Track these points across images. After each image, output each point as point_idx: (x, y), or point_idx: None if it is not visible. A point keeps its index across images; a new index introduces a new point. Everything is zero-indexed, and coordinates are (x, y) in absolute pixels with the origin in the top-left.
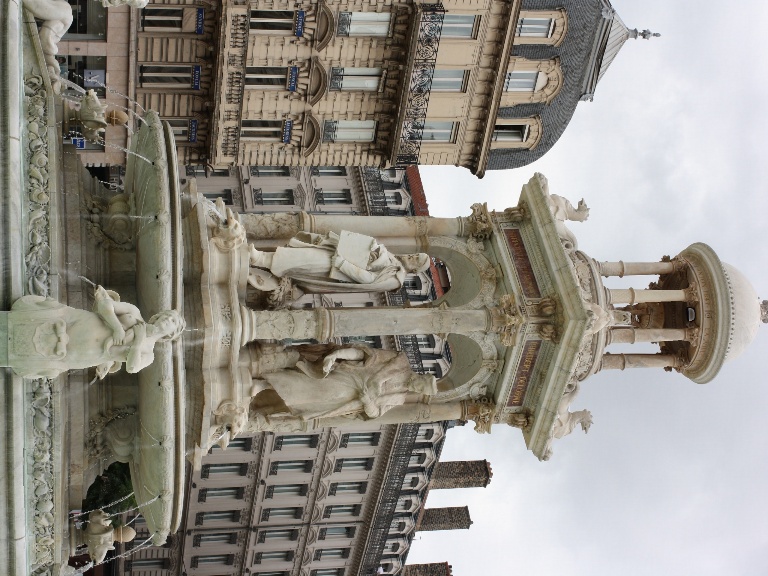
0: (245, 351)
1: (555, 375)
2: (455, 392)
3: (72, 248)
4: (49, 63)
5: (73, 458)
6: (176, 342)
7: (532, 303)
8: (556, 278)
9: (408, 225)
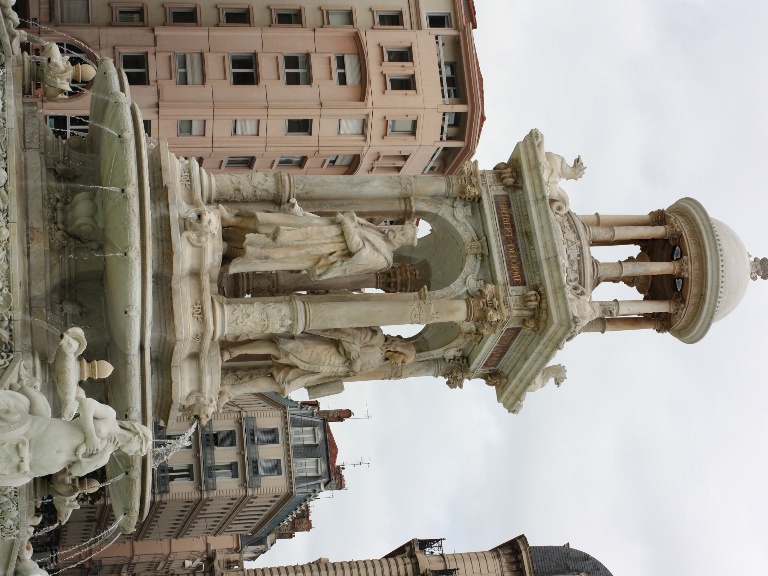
0: None
1: (535, 213)
2: (452, 291)
3: None
4: None
5: (31, 218)
6: None
7: None
8: None
9: None
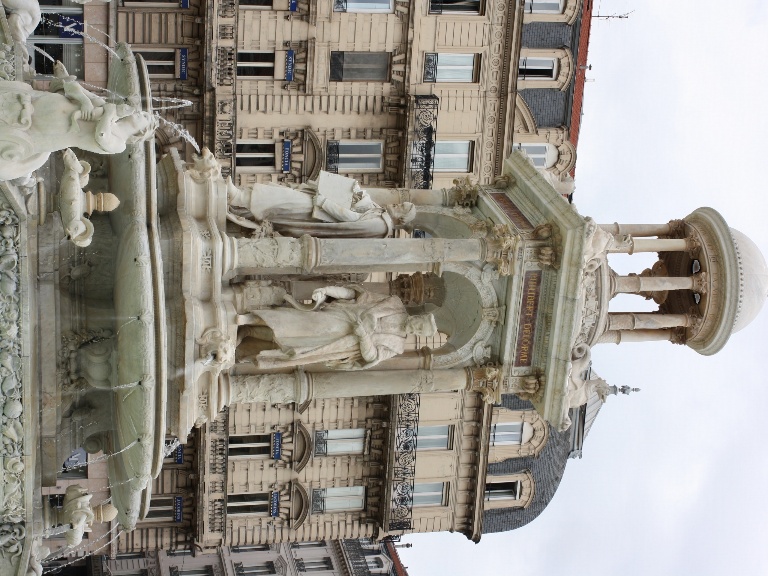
0: (228, 288)
1: (561, 309)
2: (457, 356)
3: None
4: None
5: (44, 383)
6: (152, 234)
7: (526, 232)
8: (548, 207)
9: (390, 193)
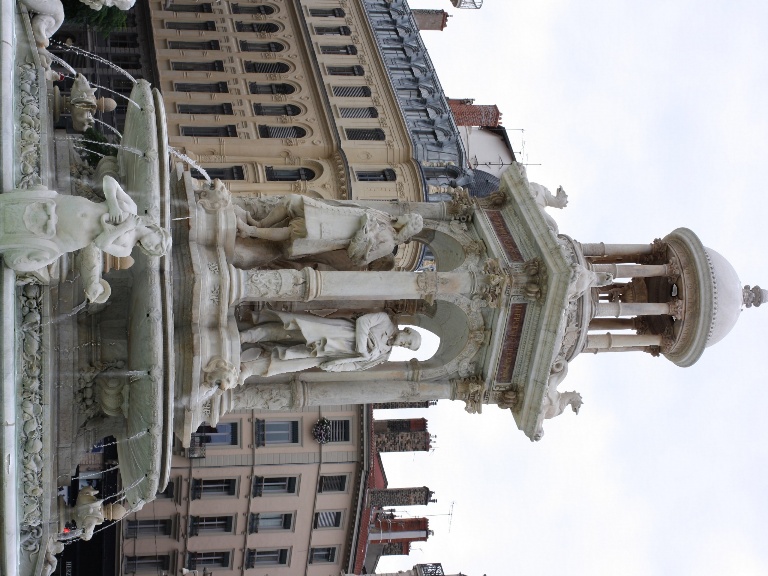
0: None
1: None
2: None
3: (63, 444)
4: None
5: None
6: None
7: (499, 389)
8: (529, 388)
9: (417, 293)
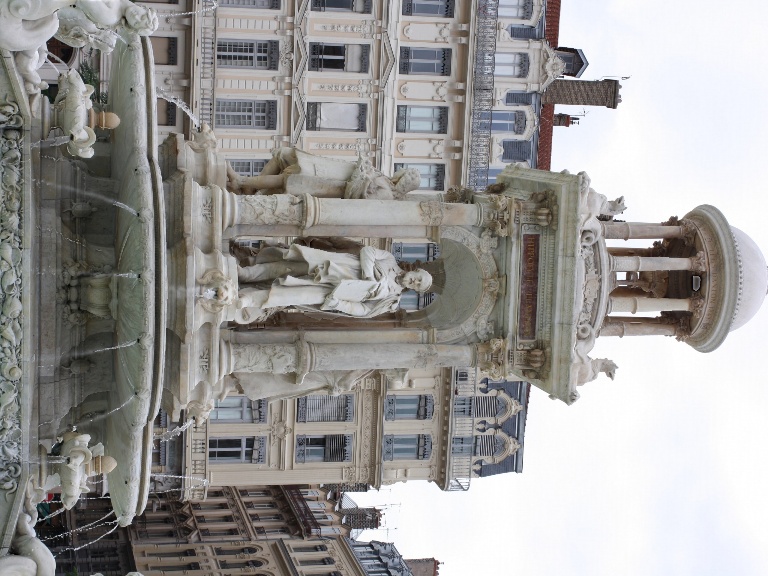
0: None
1: None
2: None
3: (45, 357)
4: (27, 80)
5: None
6: (147, 433)
7: (523, 347)
8: (555, 334)
9: (421, 221)
